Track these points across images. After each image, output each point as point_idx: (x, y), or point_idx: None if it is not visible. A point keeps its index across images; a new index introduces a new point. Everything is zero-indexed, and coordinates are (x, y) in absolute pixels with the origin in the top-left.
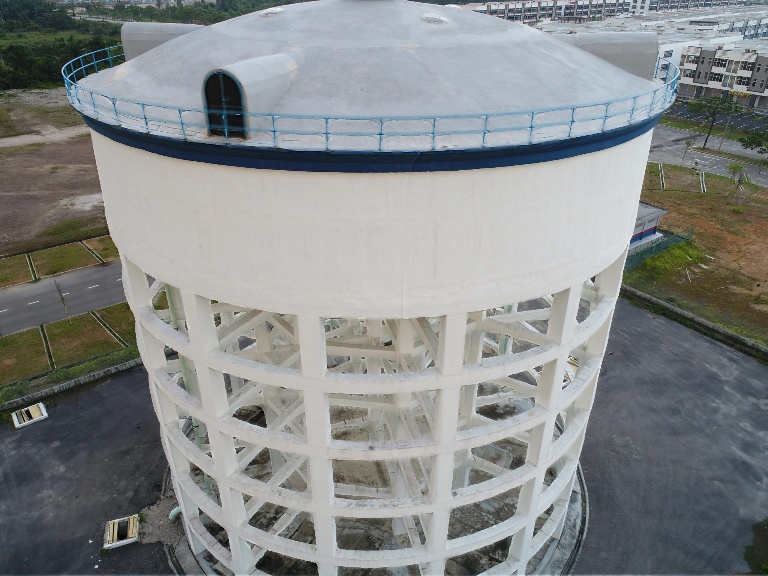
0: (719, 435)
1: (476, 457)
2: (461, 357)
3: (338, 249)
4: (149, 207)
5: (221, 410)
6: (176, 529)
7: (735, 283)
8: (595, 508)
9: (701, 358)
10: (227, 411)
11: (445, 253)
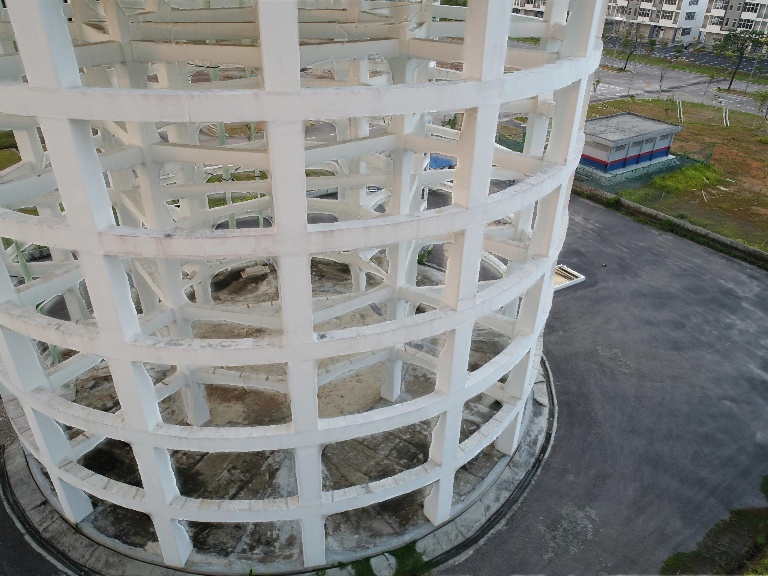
0: (733, 352)
1: (408, 347)
2: (295, 55)
3: None
4: None
5: None
6: None
7: (759, 204)
8: (565, 424)
9: (715, 274)
10: None
11: None
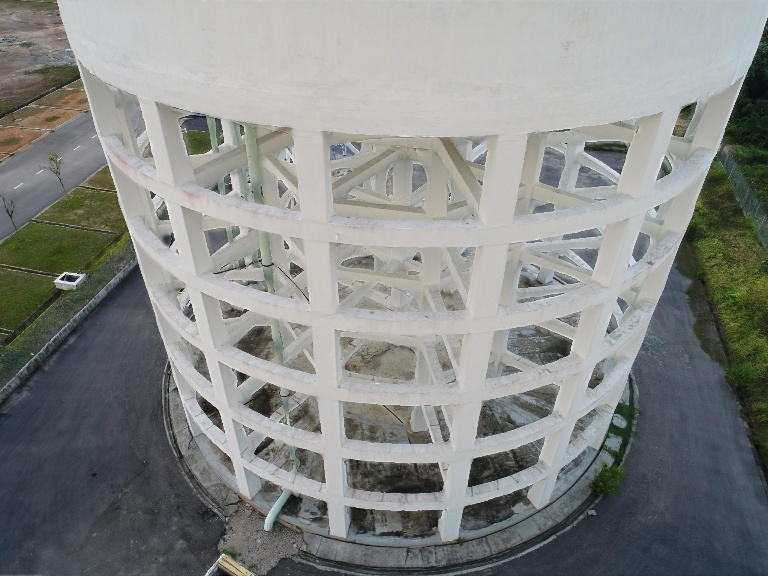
0: None
1: None
2: None
3: (728, 0)
4: (470, 3)
5: None
6: (284, 535)
7: None
8: None
9: None
10: None
11: None
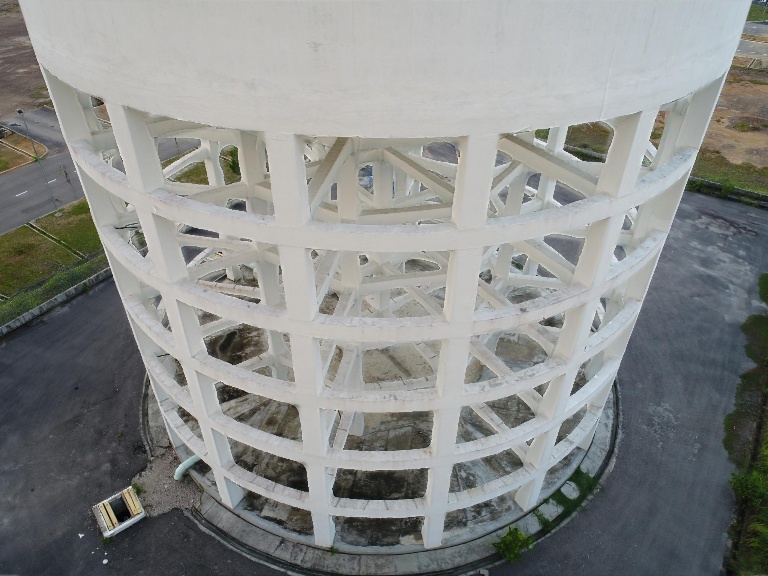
0: (679, 257)
1: None
2: (638, 170)
3: (543, 18)
4: None
5: (312, 309)
6: (189, 488)
7: None
8: None
9: None
10: (316, 310)
11: (662, 15)
